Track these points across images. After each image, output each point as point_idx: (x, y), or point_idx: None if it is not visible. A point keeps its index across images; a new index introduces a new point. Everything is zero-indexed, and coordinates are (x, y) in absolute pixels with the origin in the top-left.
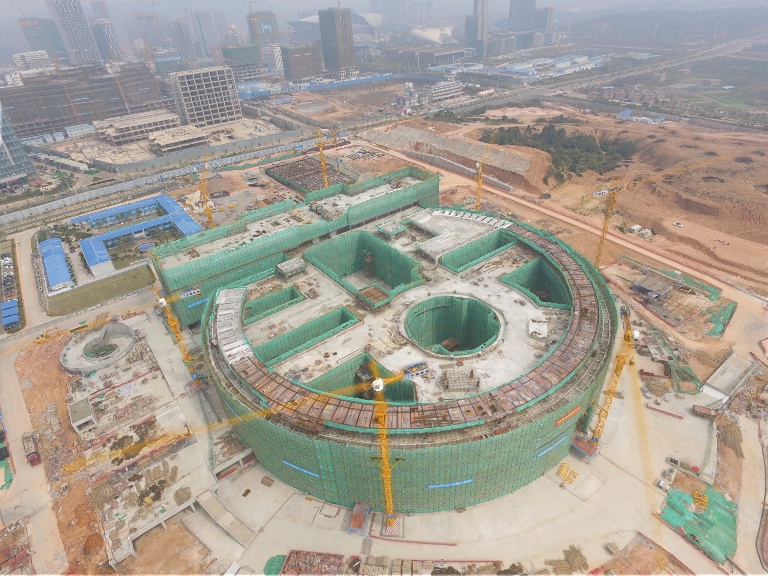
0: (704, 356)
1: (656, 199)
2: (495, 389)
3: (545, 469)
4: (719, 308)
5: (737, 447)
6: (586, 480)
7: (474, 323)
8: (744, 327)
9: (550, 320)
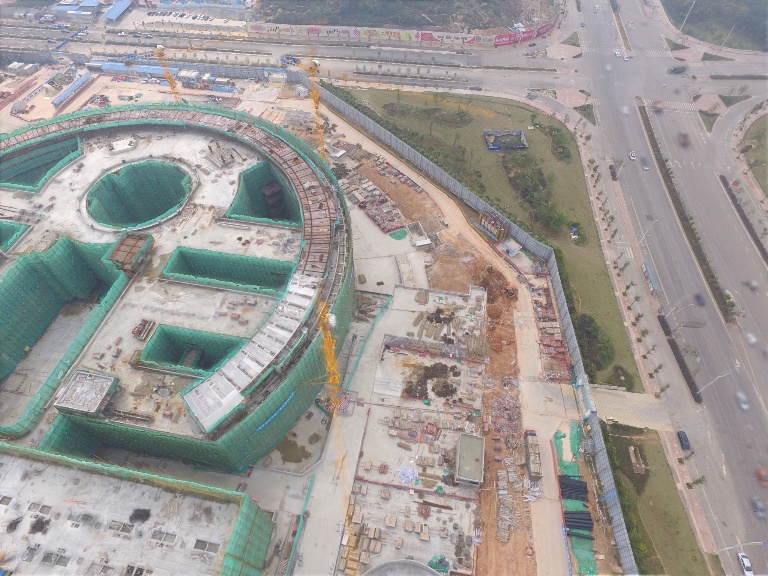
0: None
1: None
2: (221, 130)
3: None
4: None
5: None
6: None
7: None
8: (9, 128)
9: (103, 145)
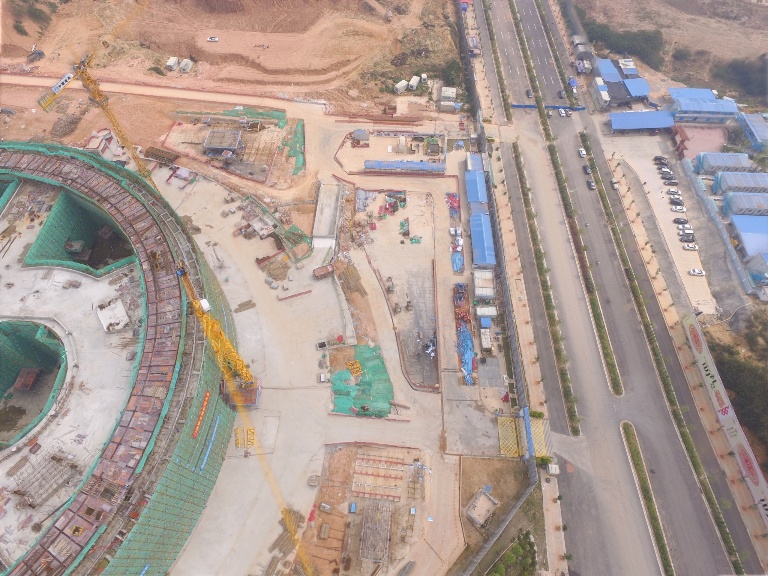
0: (301, 203)
1: (175, 8)
2: (96, 463)
3: (222, 454)
4: (291, 135)
5: (359, 287)
6: (264, 428)
7: (34, 341)
8: (318, 146)
9: (122, 290)
